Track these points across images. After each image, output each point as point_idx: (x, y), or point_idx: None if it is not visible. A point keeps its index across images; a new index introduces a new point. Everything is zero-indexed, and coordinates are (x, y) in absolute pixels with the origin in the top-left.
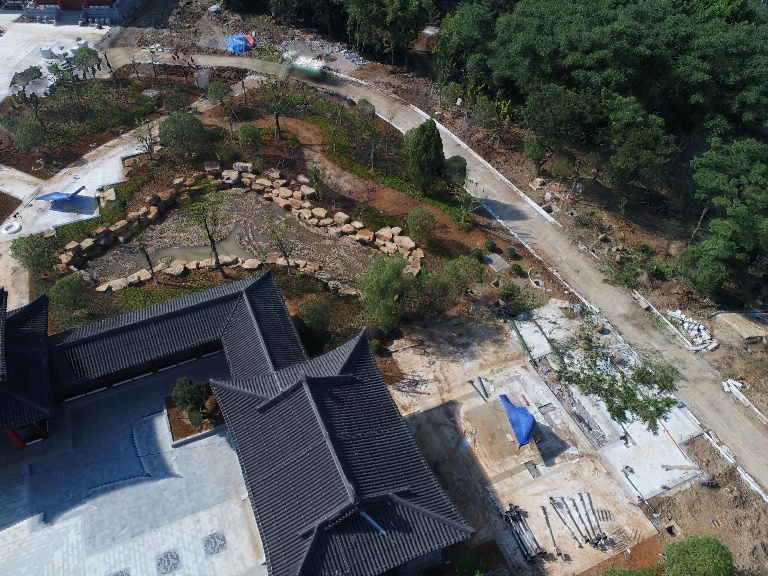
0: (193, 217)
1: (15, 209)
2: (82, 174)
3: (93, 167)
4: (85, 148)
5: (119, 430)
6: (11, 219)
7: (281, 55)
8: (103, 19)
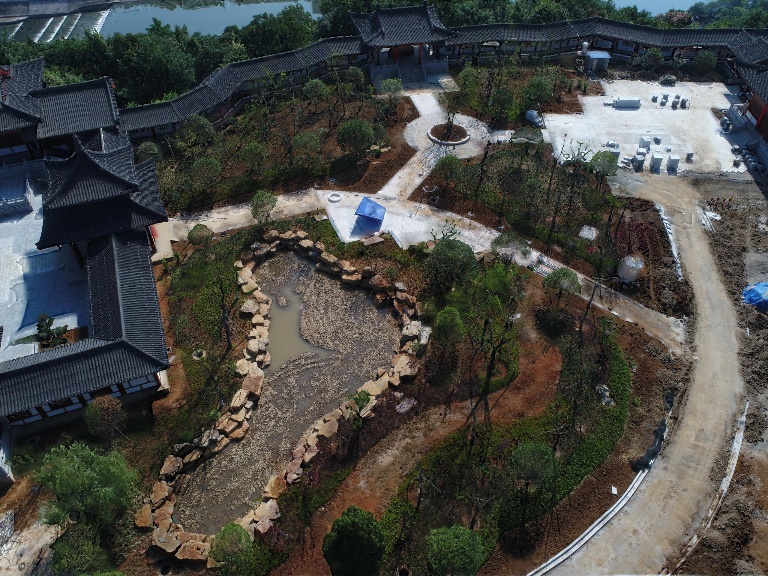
0: (350, 312)
1: (364, 193)
2: (418, 218)
3: (430, 222)
4: (464, 210)
5: (73, 305)
6: (349, 194)
7: (759, 350)
8: (752, 160)
